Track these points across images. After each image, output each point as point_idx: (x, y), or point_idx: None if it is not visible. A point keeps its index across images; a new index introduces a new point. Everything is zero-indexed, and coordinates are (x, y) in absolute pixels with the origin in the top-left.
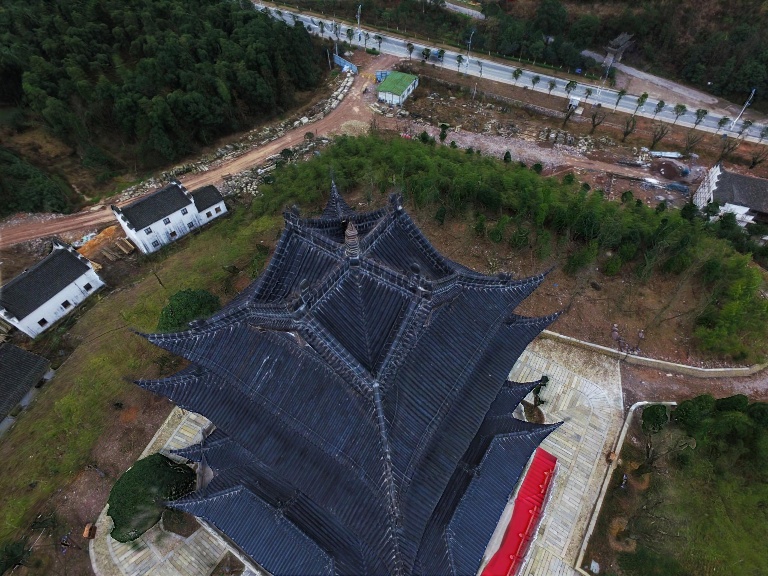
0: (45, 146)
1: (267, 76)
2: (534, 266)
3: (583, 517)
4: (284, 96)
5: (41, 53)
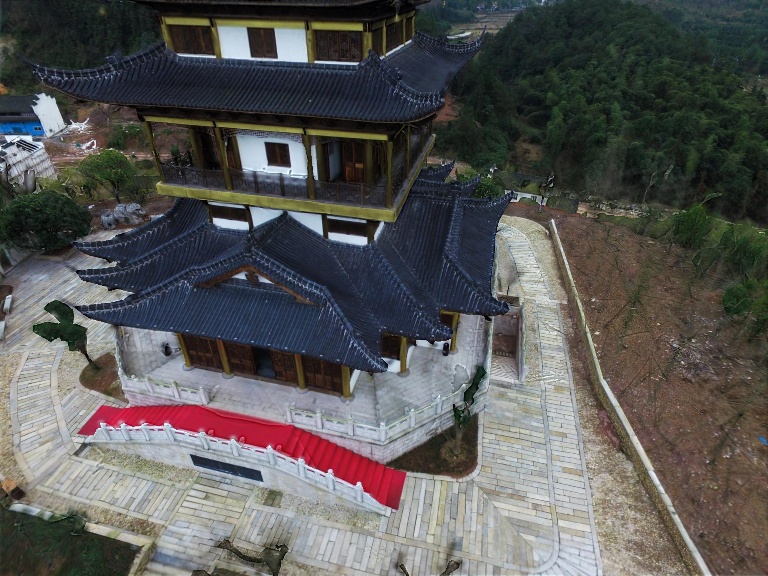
0: (532, 154)
1: (761, 180)
2: (766, 398)
3: (306, 572)
4: (765, 209)
5: (590, 99)
